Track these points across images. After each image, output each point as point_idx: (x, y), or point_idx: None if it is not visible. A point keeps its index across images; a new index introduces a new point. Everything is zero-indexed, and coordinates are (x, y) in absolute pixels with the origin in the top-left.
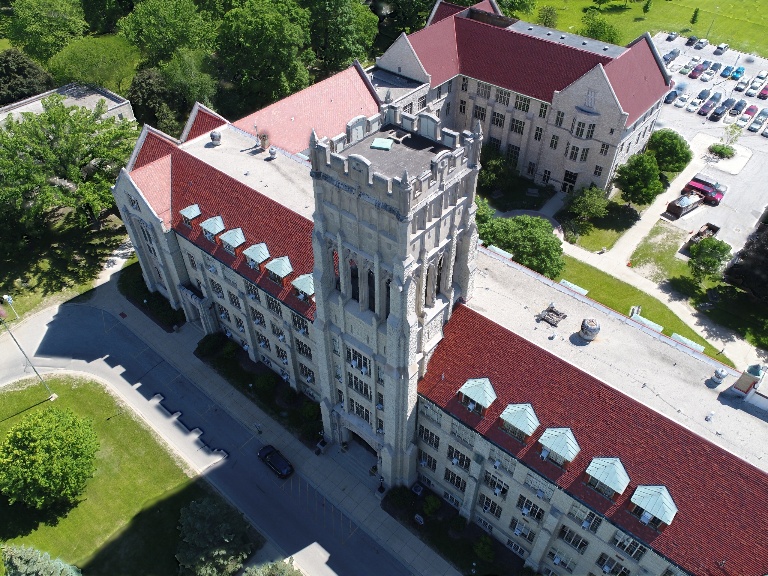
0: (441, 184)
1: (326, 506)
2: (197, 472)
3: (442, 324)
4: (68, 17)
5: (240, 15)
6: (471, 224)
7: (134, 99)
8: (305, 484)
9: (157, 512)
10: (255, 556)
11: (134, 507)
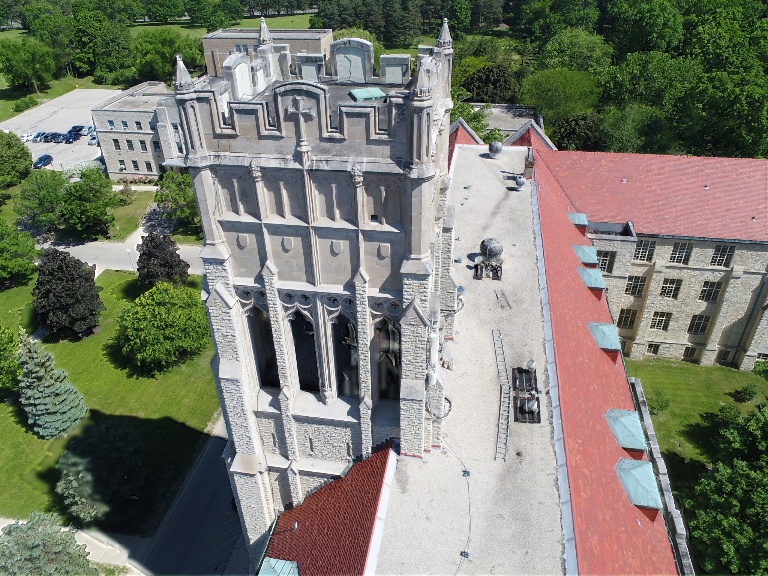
0: (298, 149)
1: (216, 572)
2: (212, 433)
3: (352, 454)
4: (590, 62)
5: (719, 78)
6: (413, 299)
7: (556, 133)
8: (237, 533)
9: (159, 430)
10: (132, 537)
11: (159, 412)
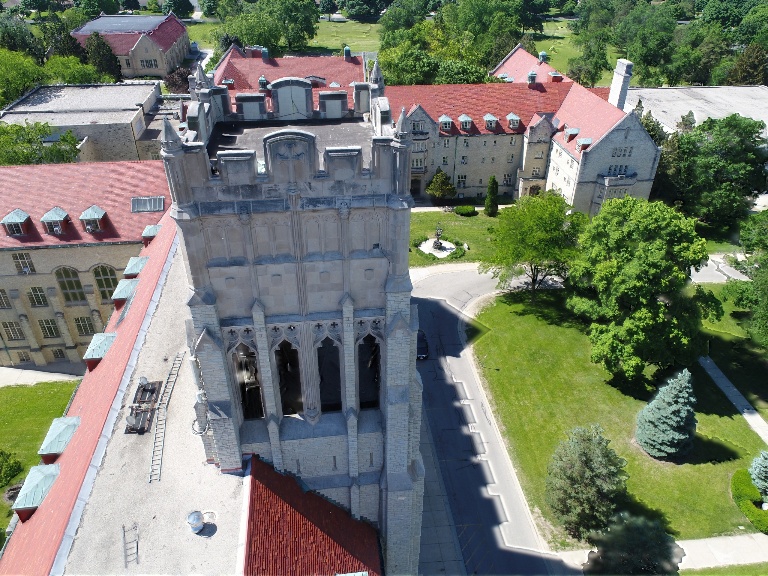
0: None
1: (473, 569)
2: None
3: None
4: None
5: None
6: None
7: None
8: None
9: None
10: None
11: None
